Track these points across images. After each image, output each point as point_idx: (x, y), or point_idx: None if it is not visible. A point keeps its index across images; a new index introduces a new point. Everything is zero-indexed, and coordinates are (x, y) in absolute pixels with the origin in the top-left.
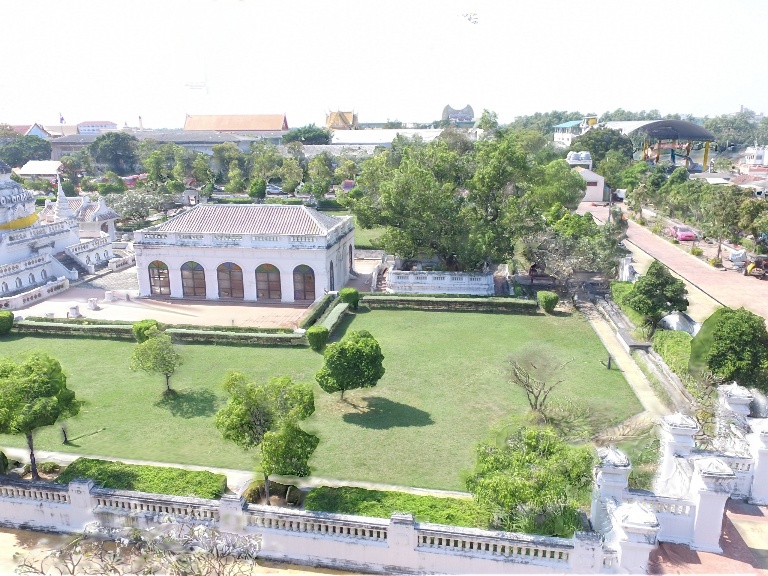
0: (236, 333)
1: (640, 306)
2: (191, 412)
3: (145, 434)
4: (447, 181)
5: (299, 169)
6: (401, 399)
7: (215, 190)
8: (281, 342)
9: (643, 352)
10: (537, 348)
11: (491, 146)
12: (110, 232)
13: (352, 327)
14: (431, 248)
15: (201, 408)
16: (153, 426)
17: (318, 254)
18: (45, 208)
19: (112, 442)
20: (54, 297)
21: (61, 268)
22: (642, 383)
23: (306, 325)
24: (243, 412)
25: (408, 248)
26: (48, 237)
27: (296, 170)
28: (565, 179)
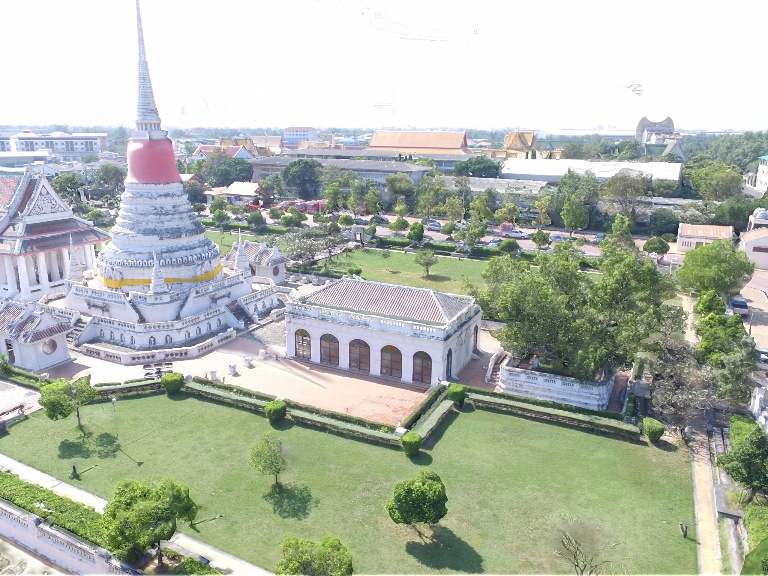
0: (346, 425)
1: (733, 474)
2: (288, 511)
3: (248, 529)
4: (568, 287)
5: (461, 208)
6: (464, 534)
7: (382, 221)
8: (382, 440)
9: (731, 522)
10: (620, 492)
11: (618, 255)
12: (280, 274)
13: (450, 430)
14: (545, 350)
15: (297, 508)
16: (256, 521)
17: (436, 344)
18: (232, 249)
19: (223, 532)
20: (222, 347)
21: (232, 318)
22: (713, 565)
23: (409, 422)
24: (296, 567)
25: (522, 348)
26: (226, 289)
27: (458, 209)
28: (726, 262)
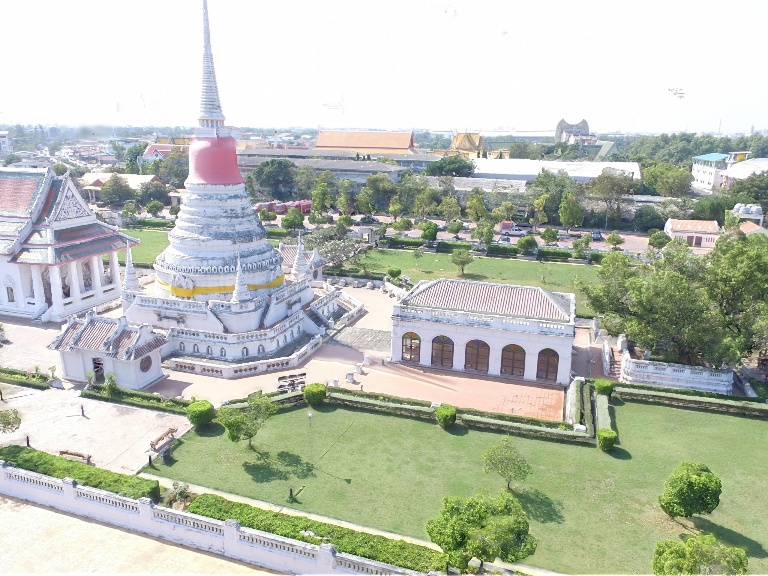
0: (527, 426)
1: None
2: (541, 516)
3: None
4: (692, 280)
5: (457, 207)
6: (722, 522)
7: (374, 222)
8: (567, 438)
9: None
10: None
11: (737, 249)
12: (319, 277)
13: (620, 424)
14: (671, 341)
15: (546, 512)
16: None
17: (565, 341)
18: None
19: None
20: (316, 355)
21: (312, 324)
22: None
23: None
24: (690, 567)
25: (651, 341)
26: (297, 294)
27: (455, 208)
28: None
